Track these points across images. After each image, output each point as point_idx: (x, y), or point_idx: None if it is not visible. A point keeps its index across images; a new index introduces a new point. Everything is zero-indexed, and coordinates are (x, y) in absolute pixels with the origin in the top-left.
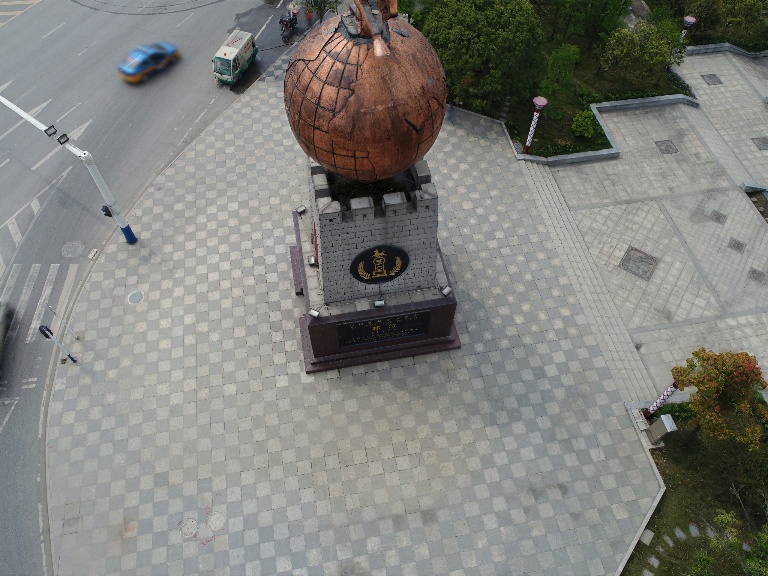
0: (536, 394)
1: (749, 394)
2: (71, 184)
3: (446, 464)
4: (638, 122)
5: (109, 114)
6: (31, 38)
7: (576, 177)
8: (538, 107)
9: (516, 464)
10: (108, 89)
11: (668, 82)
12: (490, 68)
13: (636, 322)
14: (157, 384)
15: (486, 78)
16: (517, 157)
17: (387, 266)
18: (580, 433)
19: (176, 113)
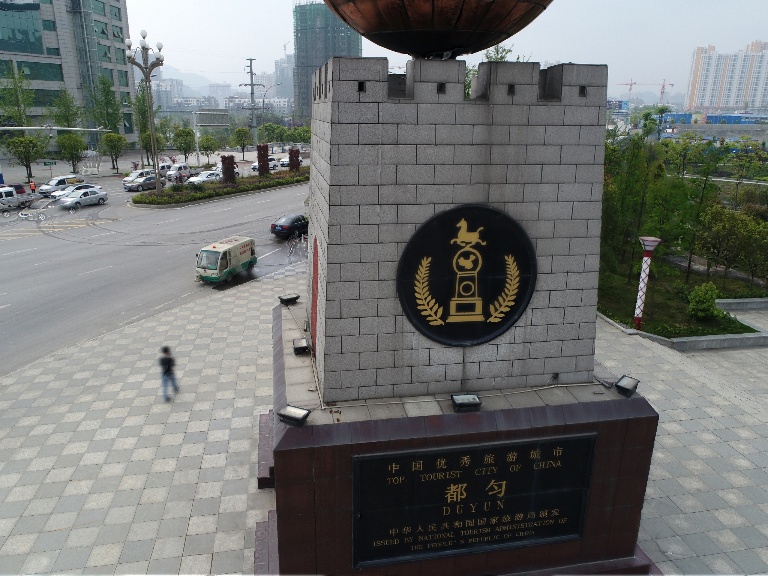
0: None
1: None
2: None
3: None
4: None
5: (38, 301)
6: None
7: (726, 361)
8: (649, 246)
9: None
10: (52, 285)
11: None
12: None
13: None
14: None
15: None
16: (627, 331)
17: (485, 286)
18: None
19: (131, 301)
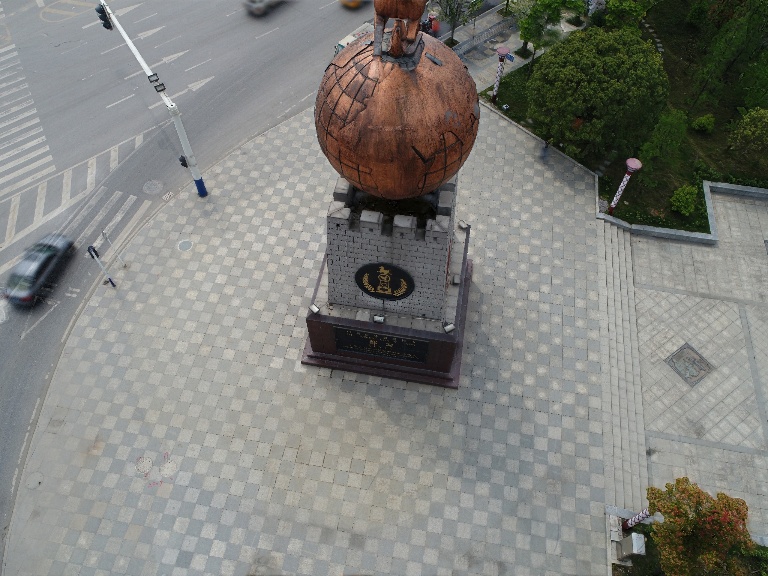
0: (515, 462)
1: (726, 547)
2: (174, 129)
3: (395, 497)
4: (754, 214)
5: (230, 75)
6: None
7: (657, 253)
8: (630, 169)
9: (464, 524)
10: (239, 52)
11: None
12: (593, 116)
13: (659, 425)
14: (171, 328)
15: (586, 126)
16: (597, 215)
17: (392, 285)
18: (544, 518)
19: (287, 88)
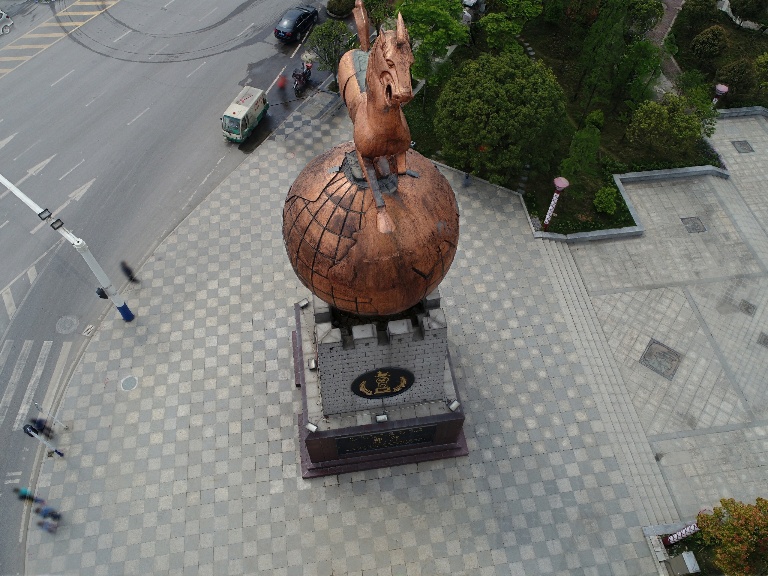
0: (547, 513)
1: None
2: (70, 250)
3: None
4: (664, 195)
5: (113, 173)
6: (39, 86)
7: (596, 257)
8: (558, 189)
9: None
10: (114, 145)
11: (696, 150)
12: (509, 143)
13: (657, 428)
14: (146, 485)
15: (504, 153)
16: (535, 235)
17: (391, 384)
18: (593, 561)
19: (182, 173)
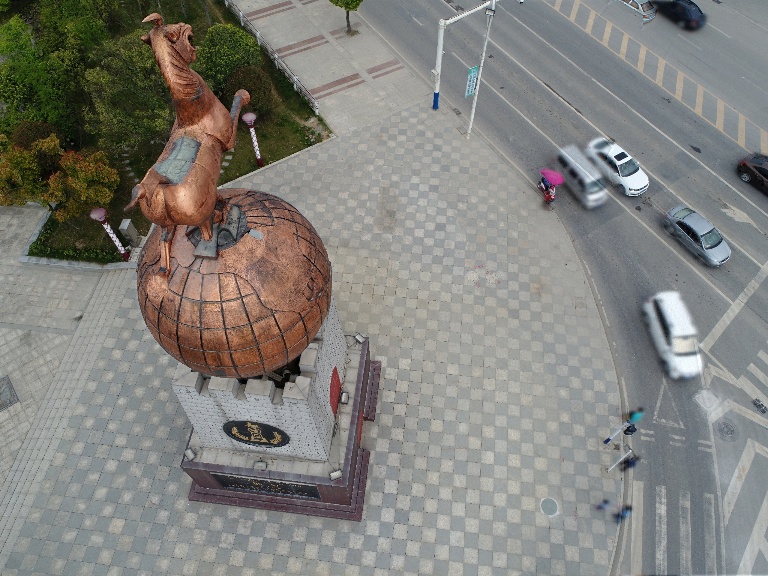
0: None
1: None
2: None
3: None
4: None
5: None
6: None
7: None
8: None
9: None
10: None
11: None
12: None
13: (59, 339)
14: (520, 394)
15: None
16: None
17: None
18: None
19: None
